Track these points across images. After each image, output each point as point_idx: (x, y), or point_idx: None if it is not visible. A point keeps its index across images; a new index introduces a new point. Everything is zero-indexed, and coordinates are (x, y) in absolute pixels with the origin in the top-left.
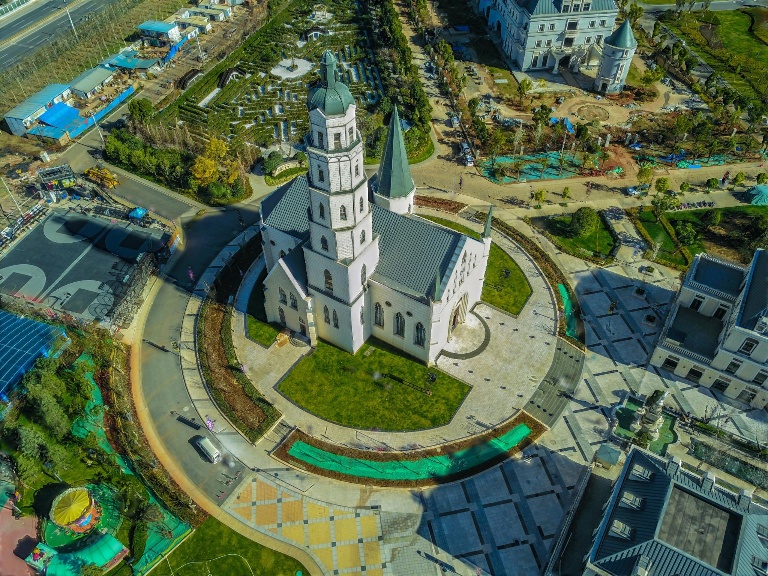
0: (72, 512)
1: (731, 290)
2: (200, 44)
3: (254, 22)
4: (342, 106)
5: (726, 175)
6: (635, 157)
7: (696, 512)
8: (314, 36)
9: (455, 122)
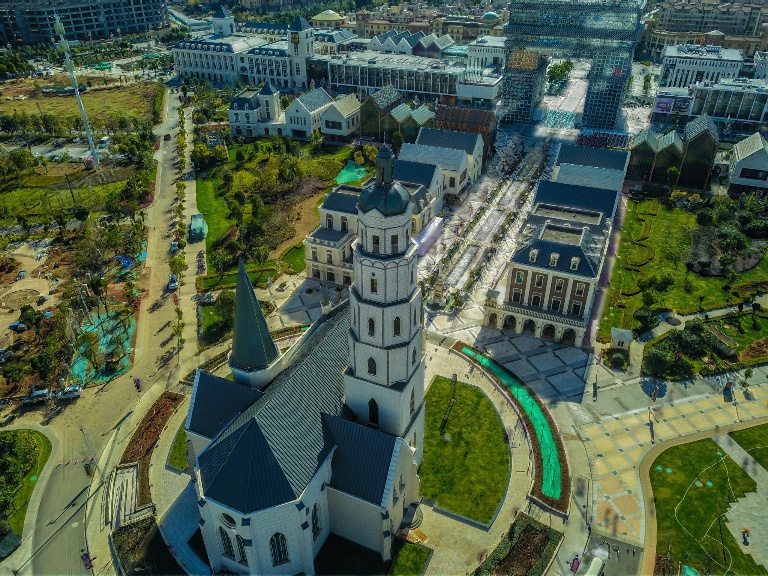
0: None
1: (340, 234)
2: None
3: None
4: None
5: (178, 235)
6: (116, 281)
7: (552, 237)
8: None
9: None
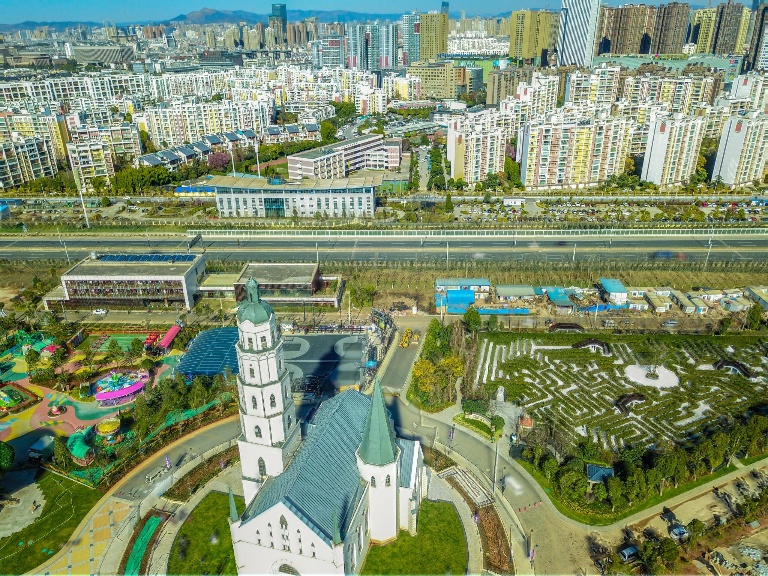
0: (104, 427)
1: None
2: (631, 316)
3: (708, 329)
4: (241, 317)
5: None
6: None
7: None
8: (732, 371)
9: (674, 530)
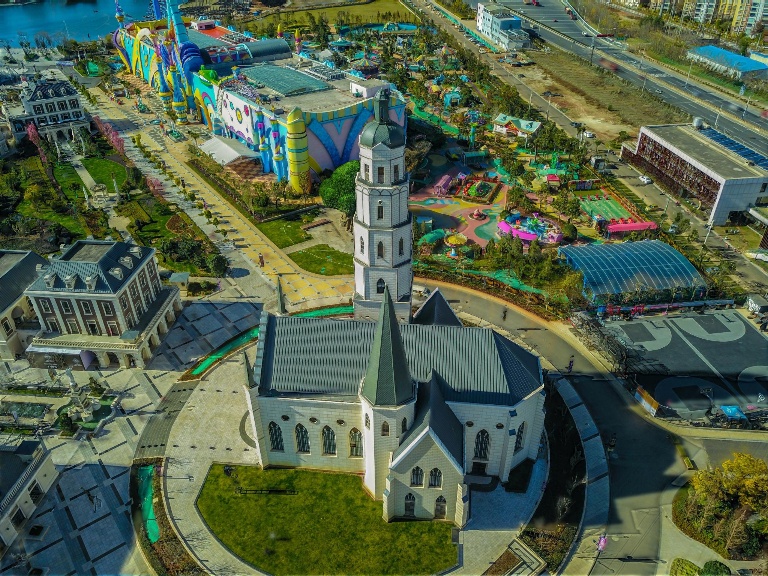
0: None
1: None
2: None
3: None
4: None
5: None
6: None
7: None
8: None
9: None
